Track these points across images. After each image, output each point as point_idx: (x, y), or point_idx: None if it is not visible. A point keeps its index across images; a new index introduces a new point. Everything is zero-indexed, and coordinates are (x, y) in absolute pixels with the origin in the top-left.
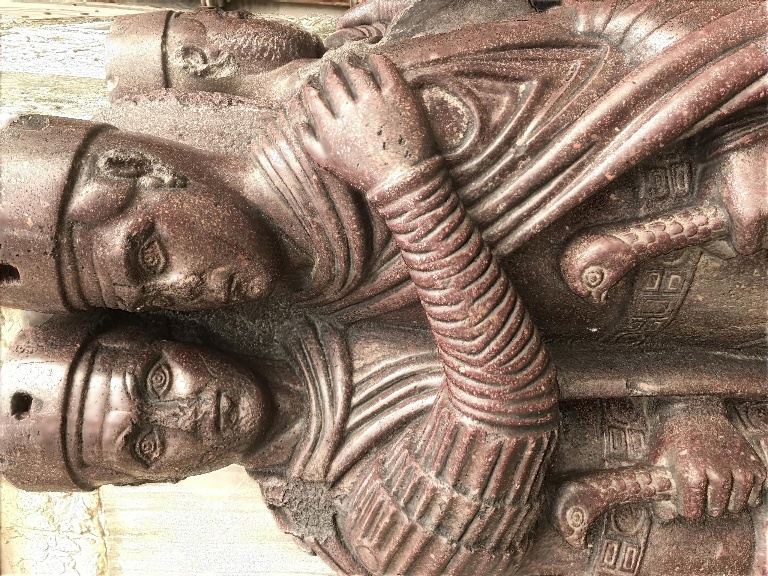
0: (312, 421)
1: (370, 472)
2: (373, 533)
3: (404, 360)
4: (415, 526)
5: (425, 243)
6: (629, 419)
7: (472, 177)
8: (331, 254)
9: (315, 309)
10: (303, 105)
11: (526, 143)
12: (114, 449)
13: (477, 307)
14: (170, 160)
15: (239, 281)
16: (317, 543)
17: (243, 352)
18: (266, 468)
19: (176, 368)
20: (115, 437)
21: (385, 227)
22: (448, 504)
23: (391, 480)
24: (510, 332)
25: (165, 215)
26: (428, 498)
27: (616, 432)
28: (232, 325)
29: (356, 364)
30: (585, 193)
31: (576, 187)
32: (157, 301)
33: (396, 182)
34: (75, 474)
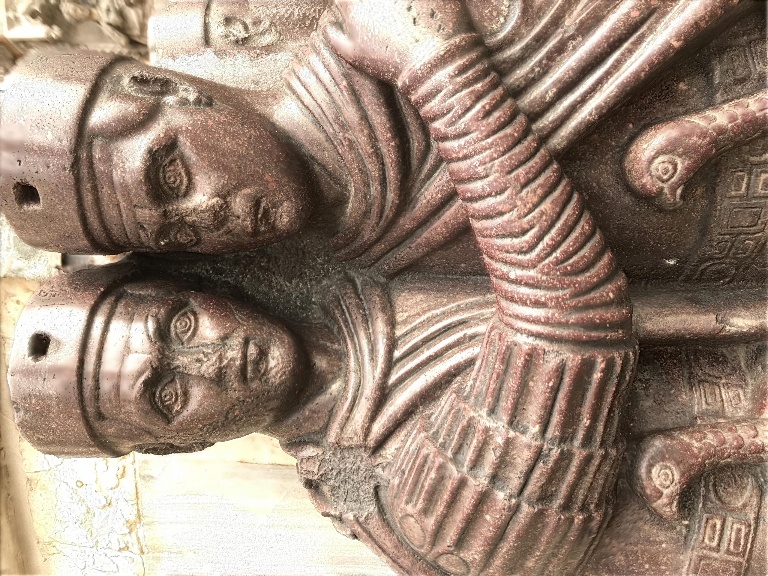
0: (350, 378)
1: (414, 429)
2: (417, 496)
3: (452, 308)
4: (465, 479)
5: (463, 124)
6: (723, 373)
7: (516, 64)
8: (366, 177)
9: (354, 261)
10: (332, 9)
11: (576, 21)
12: (132, 396)
13: (526, 194)
14: (198, 85)
15: (266, 206)
16: (356, 521)
17: (279, 315)
18: (301, 437)
19: (202, 314)
20: (133, 382)
21: (422, 136)
22: (503, 447)
23: (437, 432)
24: (567, 224)
25: (188, 131)
26: (479, 442)
27: (708, 386)
28: (268, 286)
29: (399, 316)
30: (648, 66)
31: (637, 61)
32: (182, 235)
33: (428, 58)
34: (92, 428)
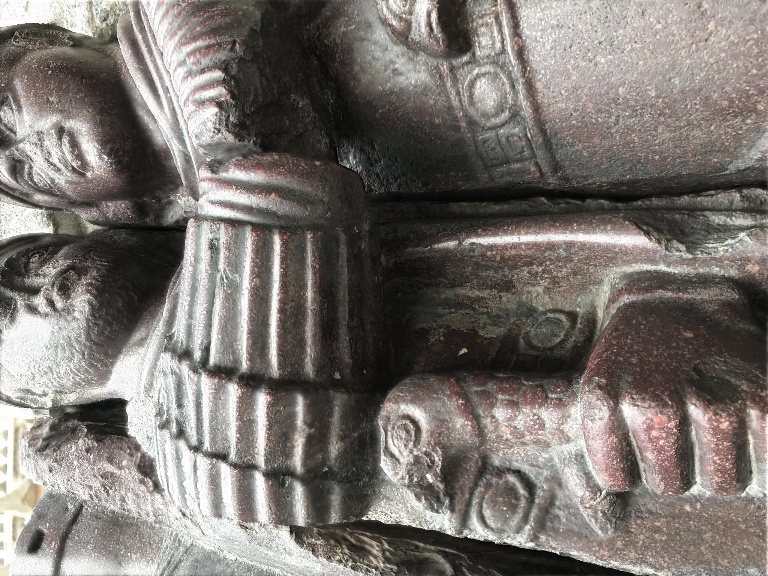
0: None
1: None
2: None
3: None
4: None
5: None
6: None
7: None
8: None
9: None
10: None
11: None
12: None
13: None
14: None
15: None
16: None
17: None
18: None
19: None
20: None
21: None
22: None
23: None
24: None
25: None
26: None
27: None
28: None
29: None
30: None
31: None
32: None
33: None
34: None
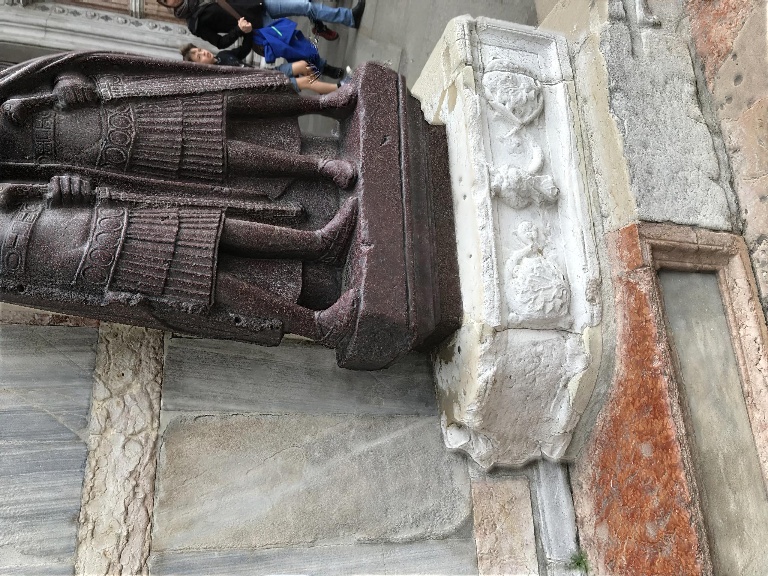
0: None
1: None
2: None
3: None
4: None
5: None
6: None
7: None
8: None
9: None
10: None
11: None
12: None
13: None
14: None
15: None
16: None
17: None
18: None
19: None
20: None
21: None
22: None
23: None
24: None
25: None
26: None
27: None
28: None
29: None
30: (3, 83)
31: (1, 82)
32: None
33: None
34: None
